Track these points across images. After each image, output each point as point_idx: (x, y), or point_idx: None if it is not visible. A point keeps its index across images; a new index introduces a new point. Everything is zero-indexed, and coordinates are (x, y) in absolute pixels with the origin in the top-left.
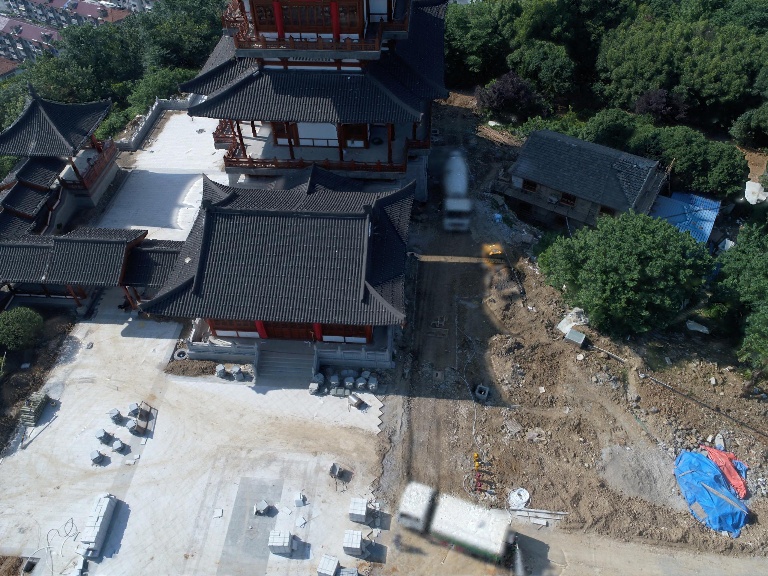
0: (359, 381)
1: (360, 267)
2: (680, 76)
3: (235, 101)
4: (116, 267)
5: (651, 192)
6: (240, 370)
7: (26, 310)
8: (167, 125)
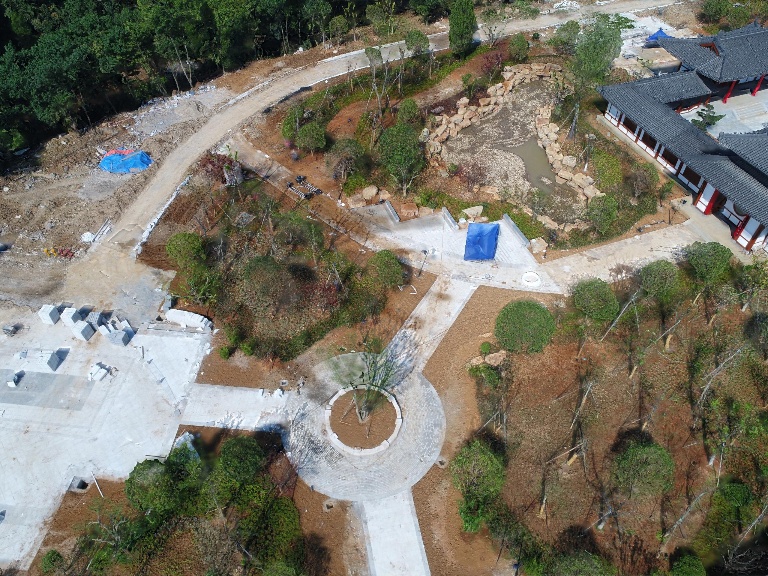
0: None
1: None
2: None
3: None
4: None
5: None
6: None
7: None
8: None
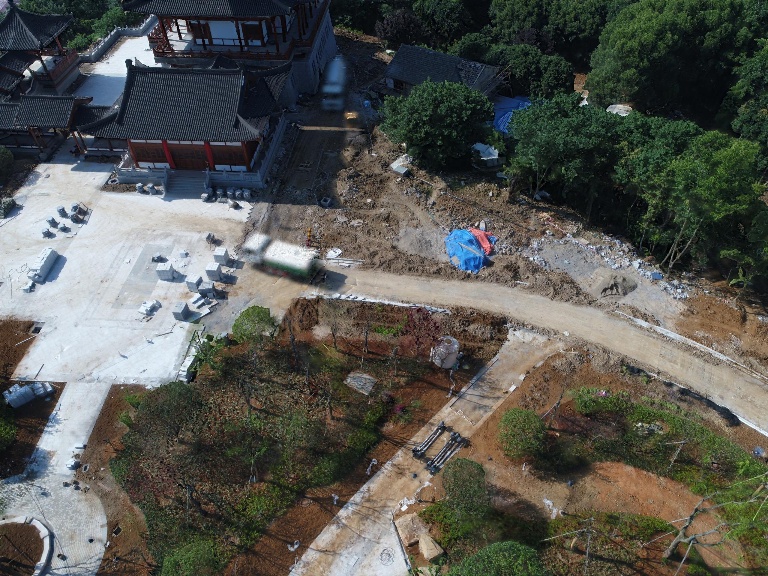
0: (237, 191)
1: (235, 106)
2: (548, 17)
3: (158, 2)
4: (66, 115)
5: (488, 87)
6: (153, 186)
7: (1, 147)
8: (122, 46)
